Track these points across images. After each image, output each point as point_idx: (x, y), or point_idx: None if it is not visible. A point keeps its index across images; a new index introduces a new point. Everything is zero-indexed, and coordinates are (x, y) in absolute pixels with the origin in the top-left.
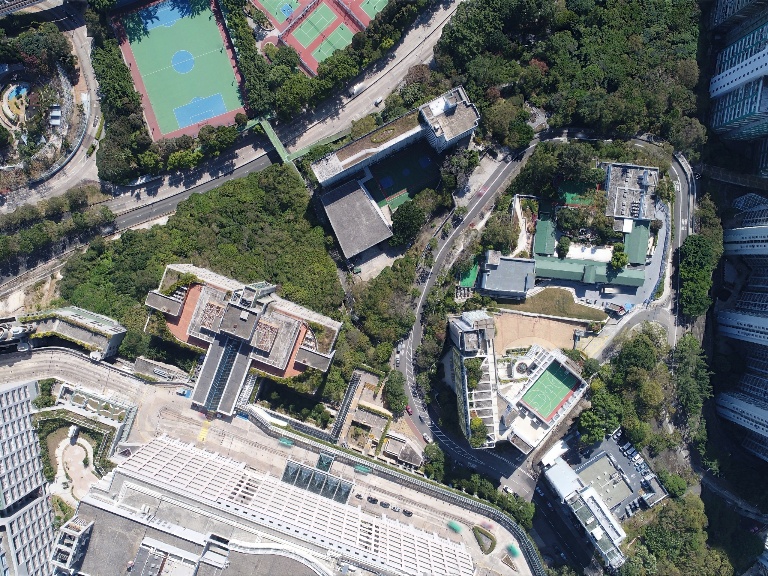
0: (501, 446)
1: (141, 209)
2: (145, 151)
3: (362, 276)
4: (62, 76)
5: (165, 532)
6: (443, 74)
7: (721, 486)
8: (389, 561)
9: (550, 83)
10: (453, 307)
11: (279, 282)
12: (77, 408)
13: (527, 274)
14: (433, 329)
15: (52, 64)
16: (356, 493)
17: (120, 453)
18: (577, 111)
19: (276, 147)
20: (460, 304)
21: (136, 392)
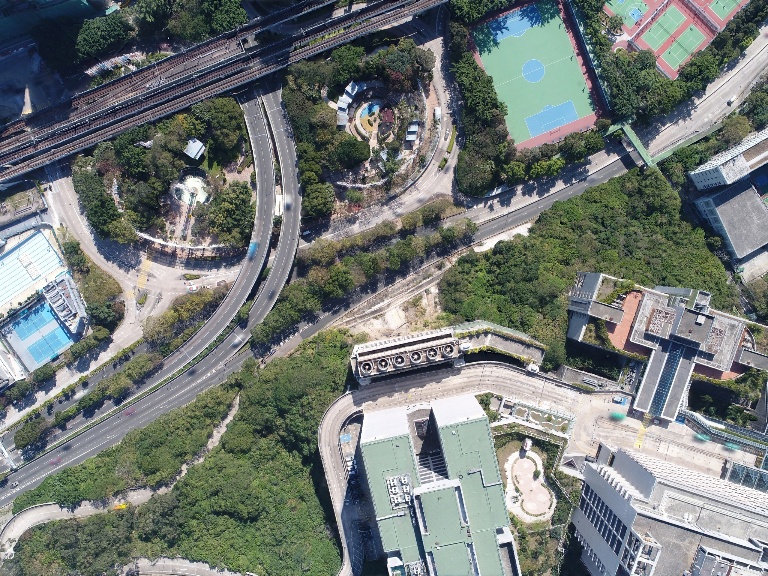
0: None
1: (496, 220)
2: (509, 162)
3: (744, 275)
4: (423, 91)
5: (720, 540)
6: None
7: None
8: None
9: None
10: None
11: (671, 285)
12: (523, 421)
13: None
14: None
15: (414, 80)
16: None
17: (564, 464)
18: None
19: (639, 151)
20: None
21: (571, 402)
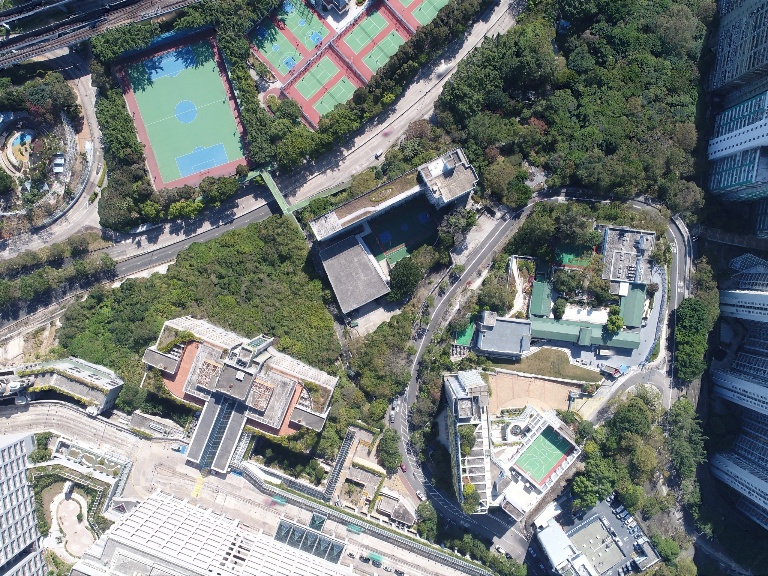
0: (494, 508)
1: (141, 256)
2: (146, 200)
3: (359, 330)
4: (66, 125)
5: None
6: (443, 130)
7: (714, 548)
8: None
9: (549, 143)
10: (449, 365)
11: (276, 335)
12: (72, 463)
13: (523, 335)
14: (428, 388)
15: (57, 113)
16: (348, 552)
17: (114, 508)
18: (575, 173)
19: (276, 199)
20: (456, 363)
21: (131, 447)
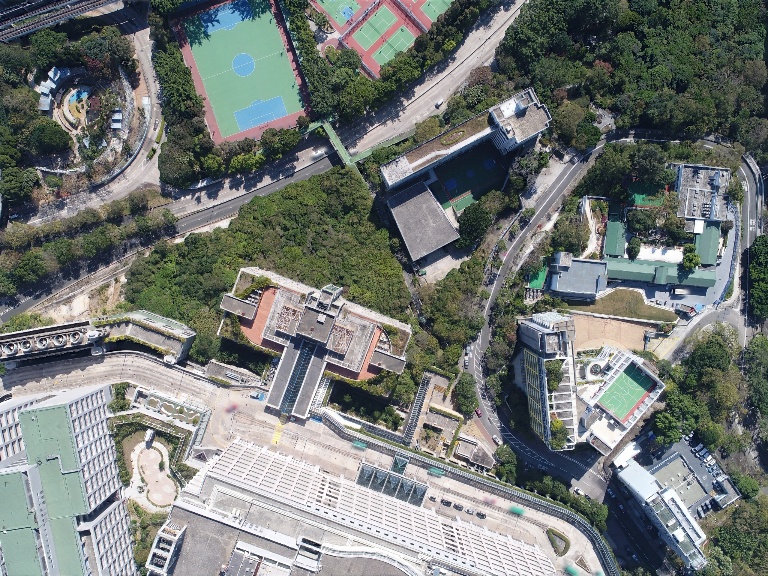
0: (575, 448)
1: (202, 212)
2: (207, 154)
3: (427, 278)
4: (124, 80)
5: (258, 536)
6: (506, 76)
7: None
8: (478, 564)
9: (616, 84)
10: (522, 309)
11: (346, 285)
12: (152, 412)
13: (599, 275)
14: (504, 331)
15: (115, 68)
16: (430, 496)
17: (195, 457)
18: (645, 112)
19: (338, 150)
20: (530, 306)
21: (209, 395)
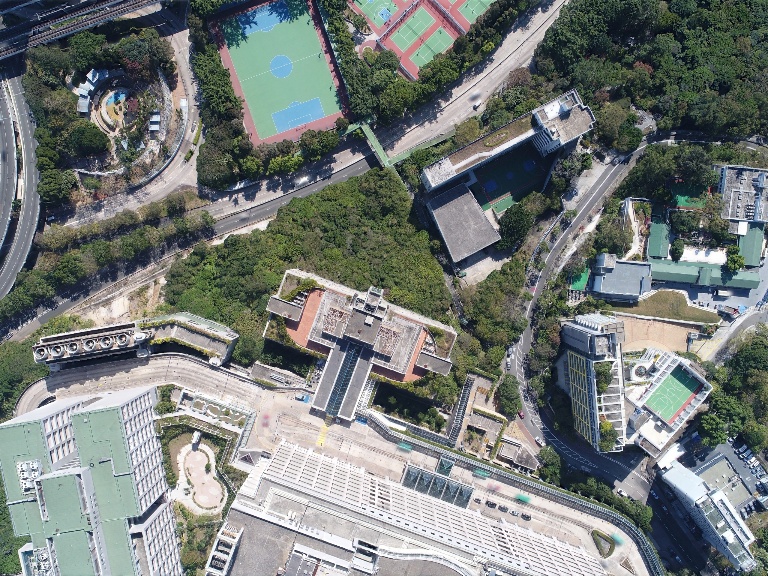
0: None
1: (239, 214)
2: (246, 156)
3: (467, 280)
4: (163, 82)
5: (315, 538)
6: (545, 77)
7: None
8: (533, 566)
9: (657, 86)
10: (565, 310)
11: (387, 286)
12: (198, 414)
13: (643, 277)
14: (547, 333)
15: (153, 70)
16: (475, 497)
17: (240, 459)
18: (688, 114)
19: (377, 151)
20: (572, 307)
21: (254, 397)
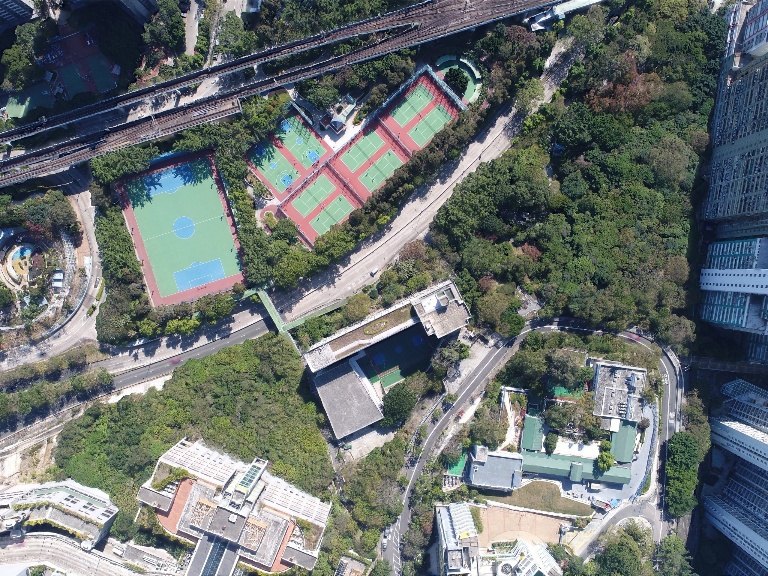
0: None
1: (138, 370)
2: (144, 318)
3: (352, 452)
4: (65, 242)
5: None
6: (438, 252)
7: None
8: None
9: (542, 271)
10: (441, 496)
11: (270, 460)
12: None
13: (514, 471)
14: (420, 520)
15: (56, 231)
16: None
17: None
18: (568, 305)
19: (272, 317)
20: (448, 494)
21: None
